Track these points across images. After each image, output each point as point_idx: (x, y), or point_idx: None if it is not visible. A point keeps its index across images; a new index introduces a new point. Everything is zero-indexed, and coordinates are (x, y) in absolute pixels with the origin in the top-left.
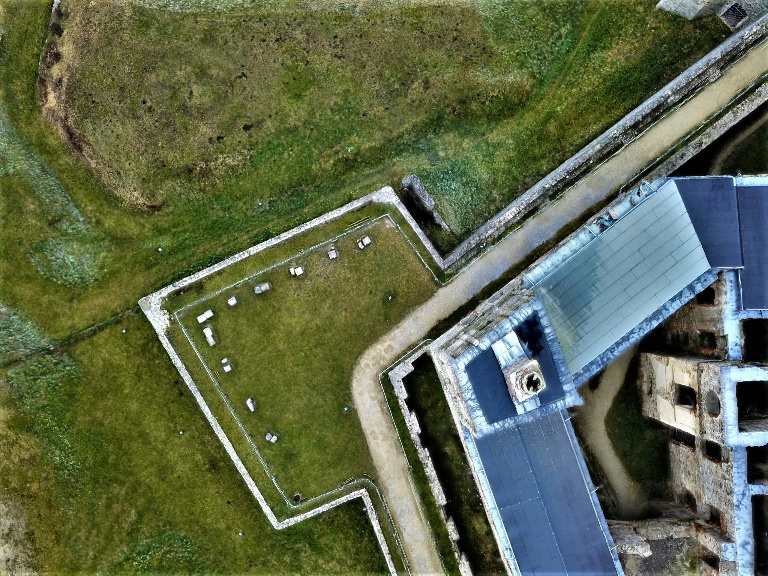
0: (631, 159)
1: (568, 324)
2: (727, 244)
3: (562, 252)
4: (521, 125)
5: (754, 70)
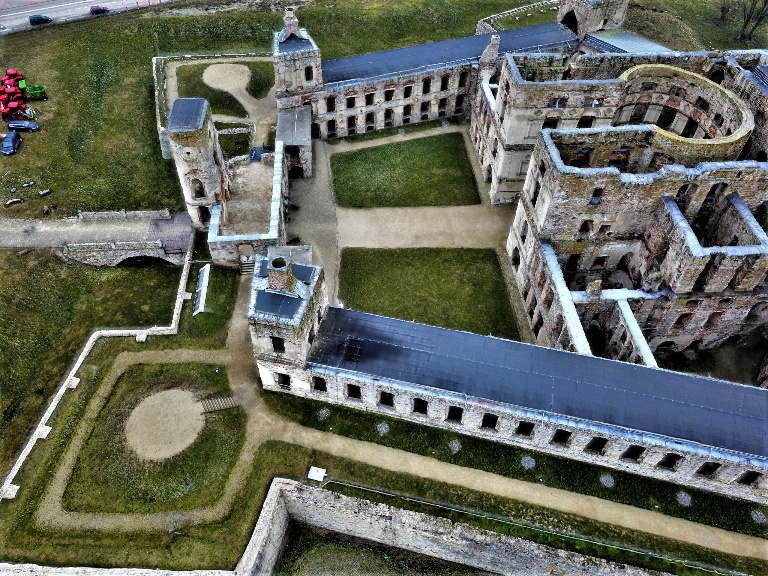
0: None
1: None
2: None
3: None
4: None
5: None
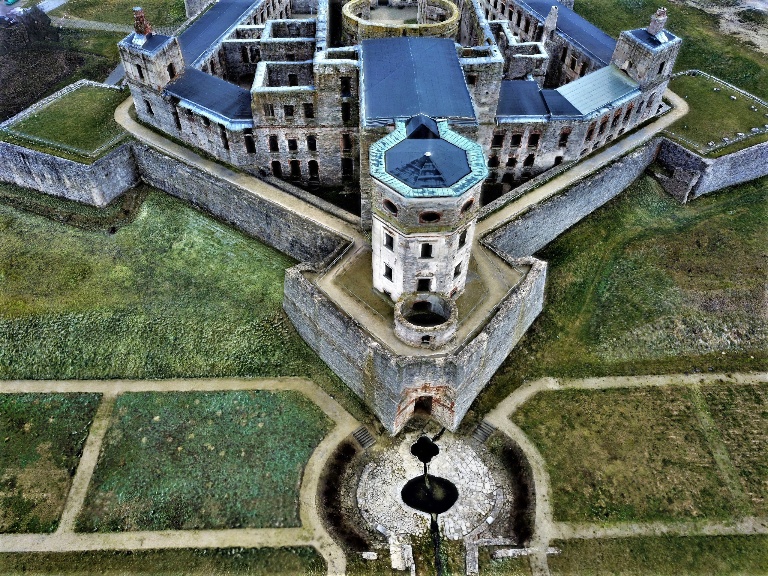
0: (574, 175)
1: (617, 77)
2: (550, 96)
3: (627, 99)
4: (623, 235)
5: (509, 211)
